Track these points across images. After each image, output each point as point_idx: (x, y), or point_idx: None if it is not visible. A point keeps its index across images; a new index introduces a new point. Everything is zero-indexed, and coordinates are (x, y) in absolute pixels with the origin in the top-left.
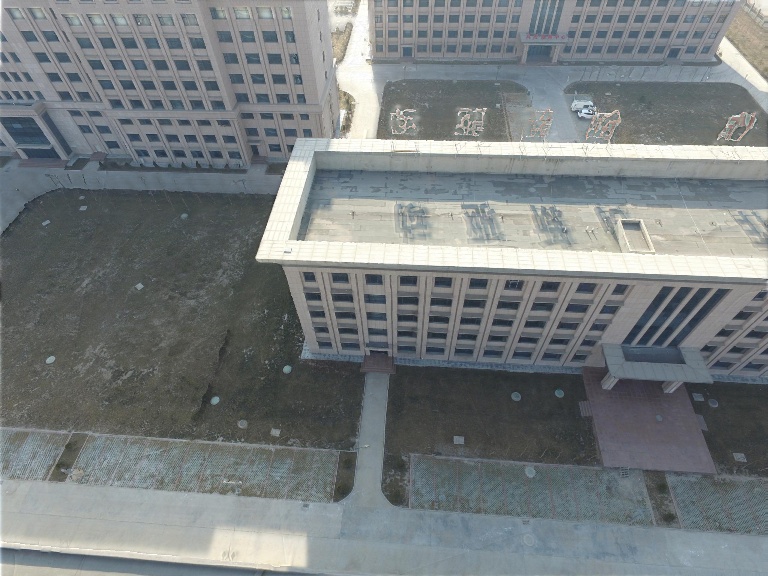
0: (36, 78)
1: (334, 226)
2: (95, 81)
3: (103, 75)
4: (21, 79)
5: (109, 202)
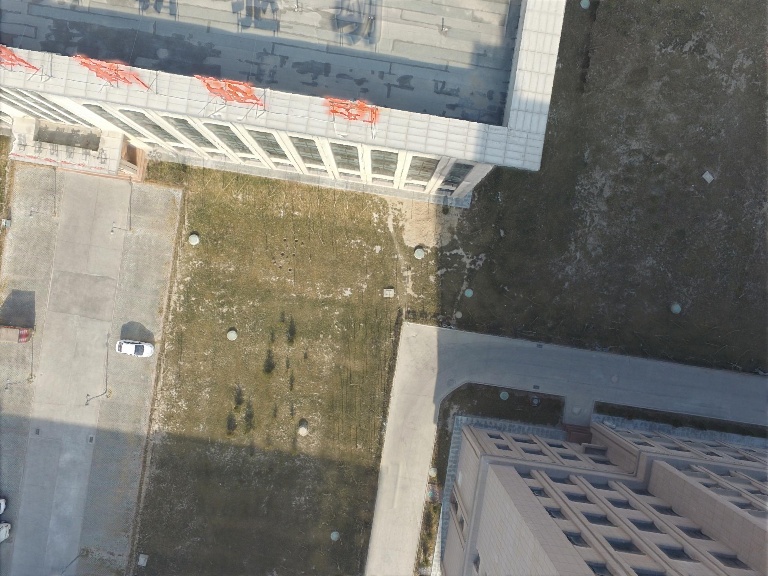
0: None
1: (471, 6)
2: None
3: None
4: None
5: None
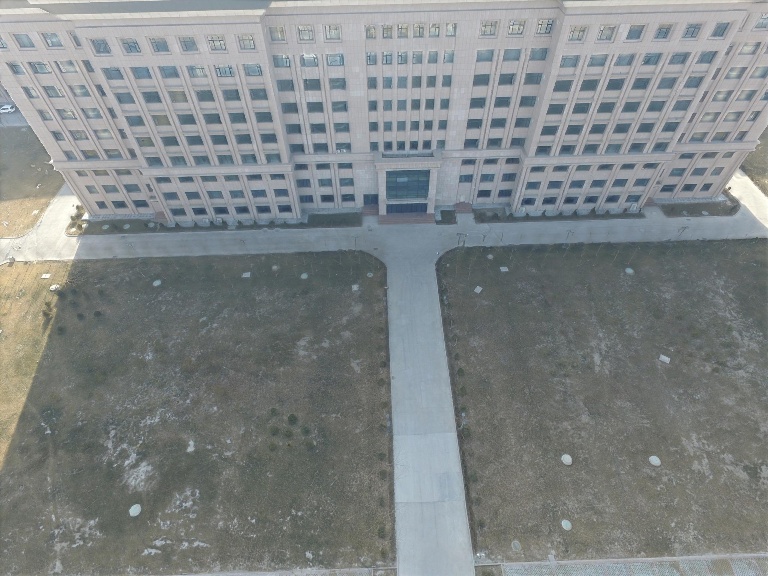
0: (452, 126)
1: None
2: (540, 127)
3: (553, 120)
4: (432, 127)
5: (528, 260)
